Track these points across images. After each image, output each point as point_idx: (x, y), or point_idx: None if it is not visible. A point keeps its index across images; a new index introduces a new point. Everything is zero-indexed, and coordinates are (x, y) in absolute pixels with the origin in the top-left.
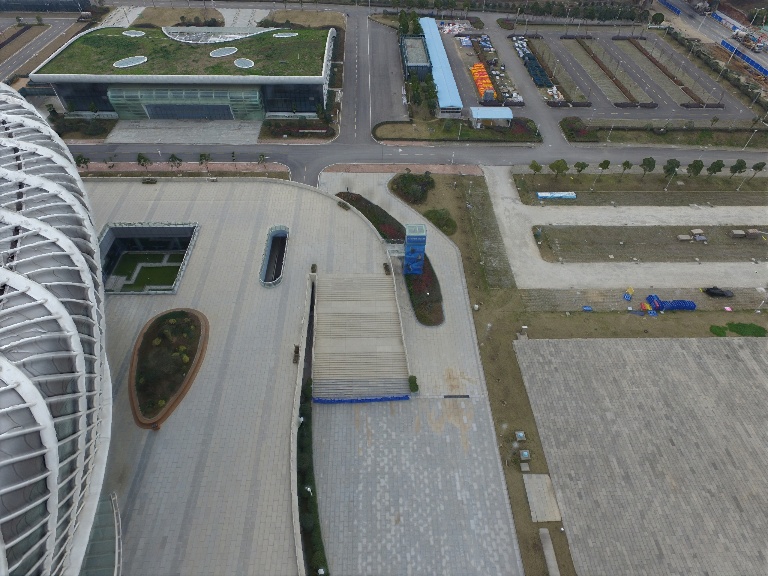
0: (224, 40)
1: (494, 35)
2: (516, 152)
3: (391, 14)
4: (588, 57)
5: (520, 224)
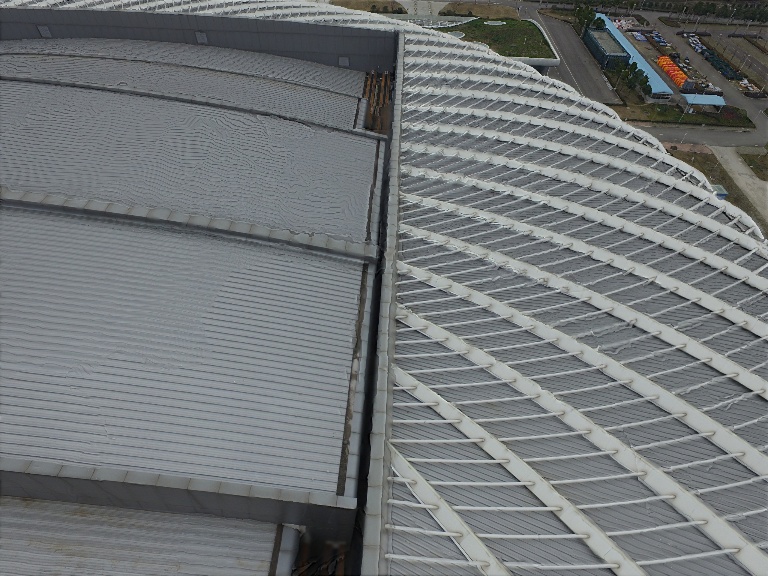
0: (446, 25)
1: (662, 32)
2: (734, 135)
3: (557, 9)
4: (763, 54)
5: (766, 196)
